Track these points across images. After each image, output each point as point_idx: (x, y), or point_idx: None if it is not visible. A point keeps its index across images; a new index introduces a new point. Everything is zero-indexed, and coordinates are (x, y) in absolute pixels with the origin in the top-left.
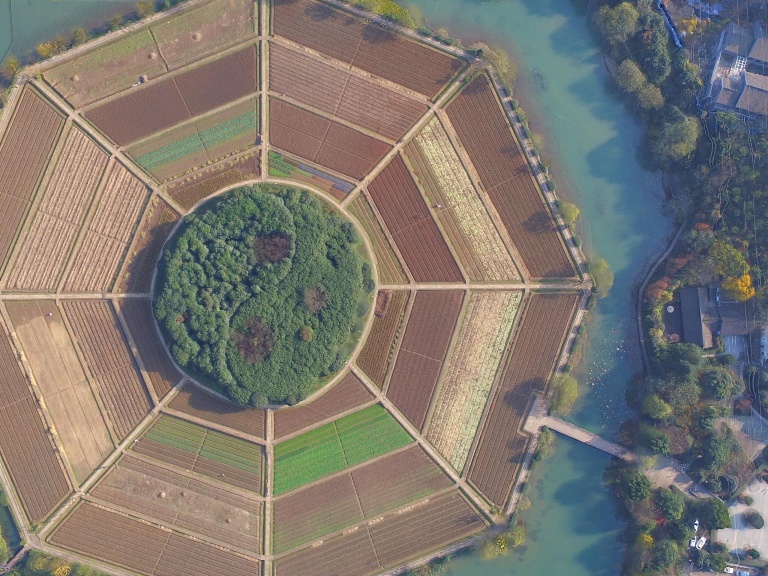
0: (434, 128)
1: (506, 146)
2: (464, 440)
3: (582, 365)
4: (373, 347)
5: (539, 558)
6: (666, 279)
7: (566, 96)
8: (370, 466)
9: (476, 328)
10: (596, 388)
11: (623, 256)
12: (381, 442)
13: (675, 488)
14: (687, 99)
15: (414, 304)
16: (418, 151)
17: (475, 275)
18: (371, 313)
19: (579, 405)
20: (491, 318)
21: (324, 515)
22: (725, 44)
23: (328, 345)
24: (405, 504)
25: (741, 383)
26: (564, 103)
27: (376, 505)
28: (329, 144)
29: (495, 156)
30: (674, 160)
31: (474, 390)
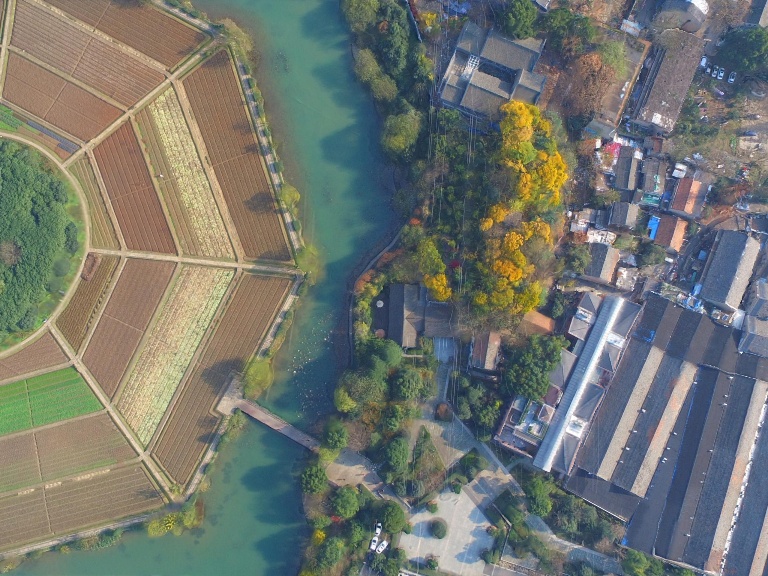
0: (168, 98)
1: (239, 123)
2: (154, 413)
3: (287, 351)
4: (75, 309)
5: (216, 543)
6: (370, 271)
7: (308, 80)
8: (55, 429)
9: (182, 302)
10: (297, 376)
11: (344, 246)
12: (70, 406)
13: (362, 487)
14: (416, 93)
15: (123, 271)
16: (149, 119)
17: (189, 249)
18: (77, 275)
19: (278, 391)
20: (199, 293)
21: (2, 473)
22: (457, 41)
23: (18, 300)
24: (85, 471)
25: (432, 385)
26: (305, 87)
27: (55, 469)
28: (61, 103)
29: (226, 132)
30: (397, 153)
31: (171, 364)
